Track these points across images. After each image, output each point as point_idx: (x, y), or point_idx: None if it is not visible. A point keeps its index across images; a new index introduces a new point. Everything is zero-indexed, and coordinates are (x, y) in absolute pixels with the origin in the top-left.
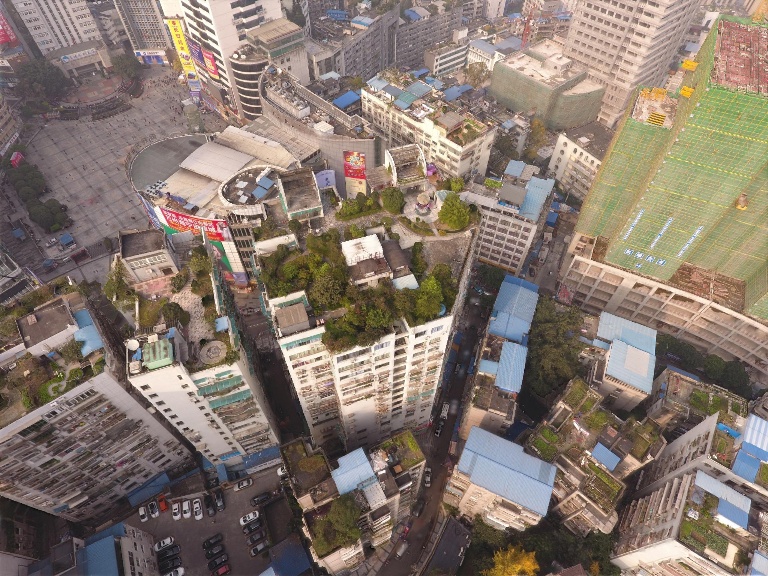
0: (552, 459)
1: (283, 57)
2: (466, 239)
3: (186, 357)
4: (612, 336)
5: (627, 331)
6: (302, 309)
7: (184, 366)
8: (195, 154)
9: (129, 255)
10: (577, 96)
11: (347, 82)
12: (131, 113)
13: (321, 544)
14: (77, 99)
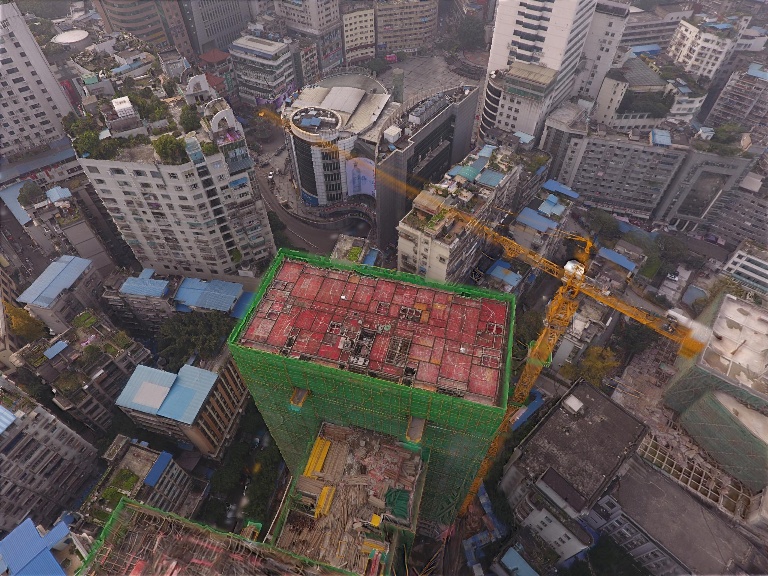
0: (72, 325)
1: (515, 97)
2: (153, 163)
3: (94, 91)
4: (183, 377)
5: (190, 393)
6: (92, 102)
7: (92, 93)
8: (346, 88)
9: (161, 55)
10: (728, 415)
11: (532, 153)
12: (471, 82)
13: (21, 189)
14: (470, 56)
